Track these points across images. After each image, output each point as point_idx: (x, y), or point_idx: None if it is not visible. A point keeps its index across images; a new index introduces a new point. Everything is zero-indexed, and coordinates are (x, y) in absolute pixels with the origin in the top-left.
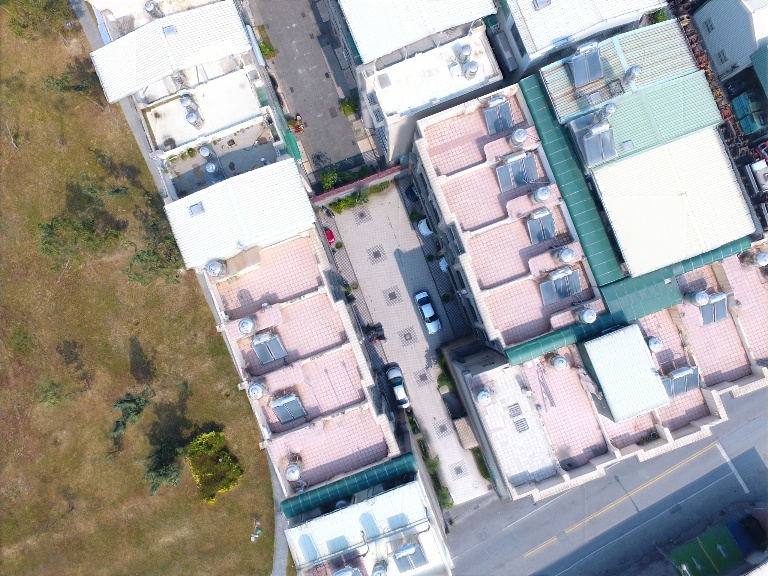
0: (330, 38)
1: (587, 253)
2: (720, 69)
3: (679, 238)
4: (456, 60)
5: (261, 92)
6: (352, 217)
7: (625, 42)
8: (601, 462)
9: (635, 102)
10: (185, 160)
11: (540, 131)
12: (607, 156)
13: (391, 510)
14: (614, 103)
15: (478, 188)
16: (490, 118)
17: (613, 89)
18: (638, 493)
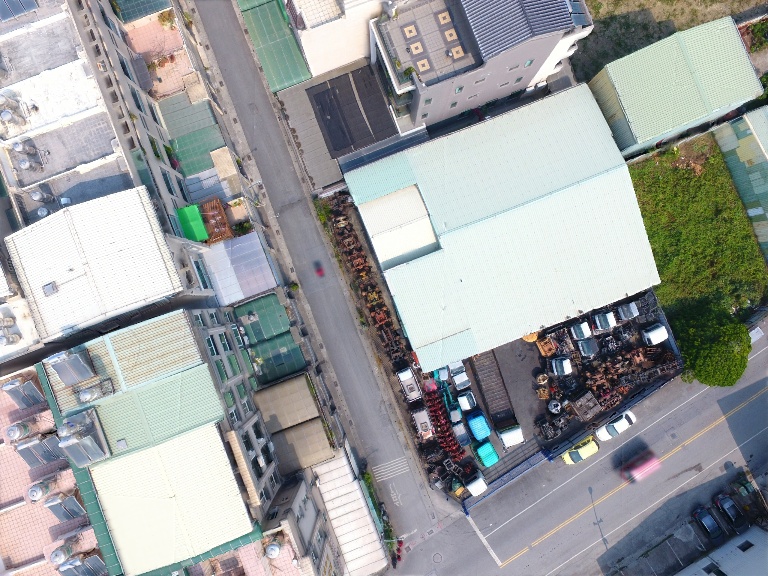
0: None
1: (98, 543)
2: None
3: (168, 541)
4: None
5: None
6: None
7: (117, 340)
8: None
9: (128, 401)
10: None
11: (53, 417)
12: (95, 458)
13: None
14: (108, 401)
15: (9, 463)
16: (15, 396)
17: (105, 388)
18: None
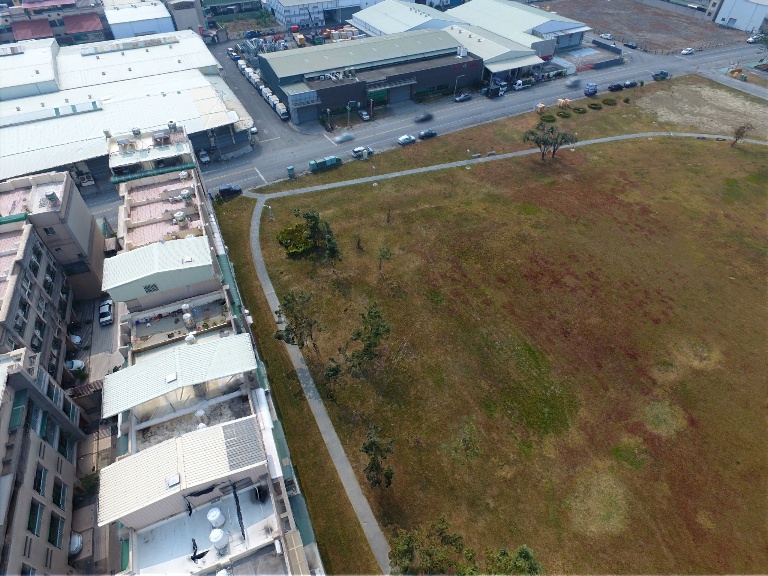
0: (91, 571)
1: None
2: None
3: None
4: None
5: None
6: None
7: None
8: (6, 184)
9: None
10: None
11: None
12: None
13: (130, 159)
14: None
15: None
16: None
17: None
18: None
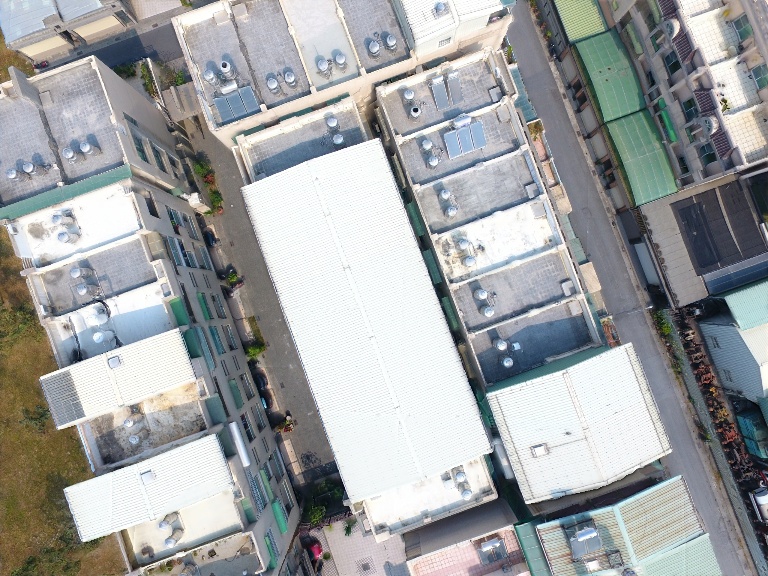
0: None
1: None
2: (725, 383)
3: None
4: (449, 470)
5: (245, 500)
6: (341, 527)
7: (626, 511)
8: None
9: None
10: (163, 570)
11: None
12: None
13: None
14: (613, 572)
15: None
16: (483, 553)
17: (612, 559)
18: None
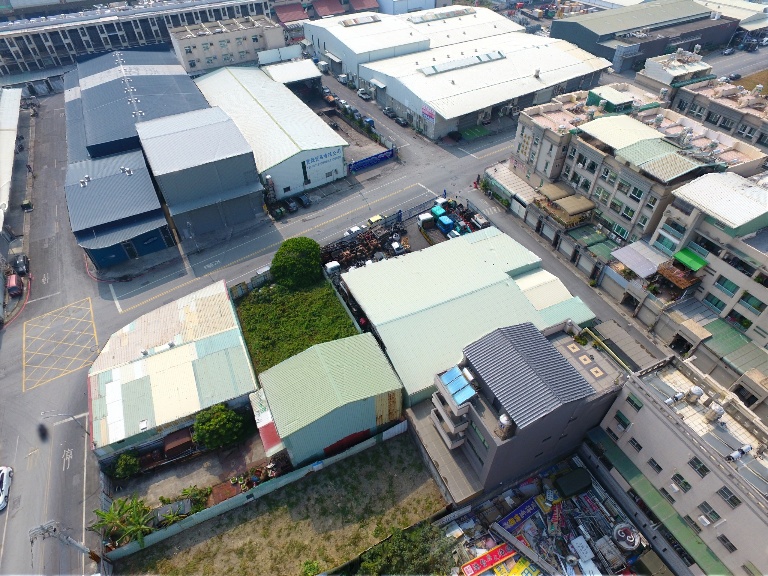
0: None
1: None
2: None
3: None
4: None
5: None
6: None
7: None
8: None
9: None
10: None
11: None
12: None
13: None
14: None
15: None
16: None
17: (683, 153)
18: (512, 145)
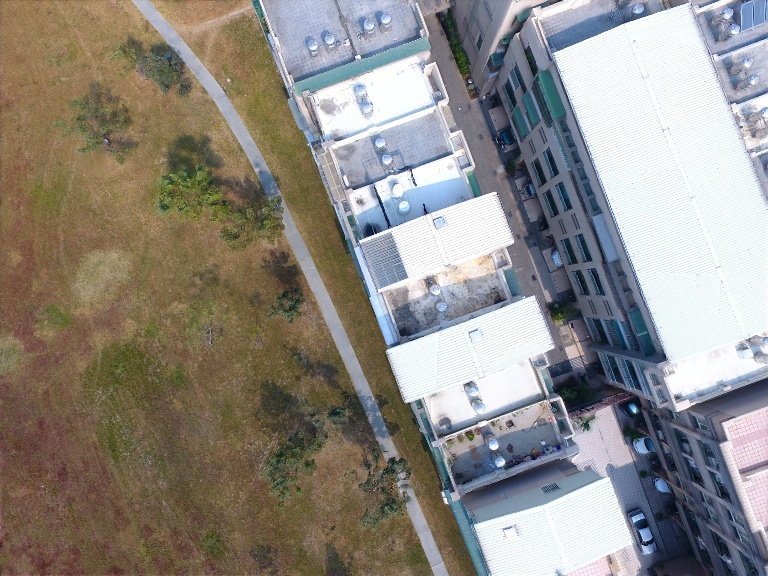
0: (537, 239)
1: None
2: None
3: None
4: (744, 340)
5: None
6: None
7: None
8: None
9: None
10: (461, 441)
11: None
12: None
13: None
14: None
15: None
16: None
17: None
18: None
